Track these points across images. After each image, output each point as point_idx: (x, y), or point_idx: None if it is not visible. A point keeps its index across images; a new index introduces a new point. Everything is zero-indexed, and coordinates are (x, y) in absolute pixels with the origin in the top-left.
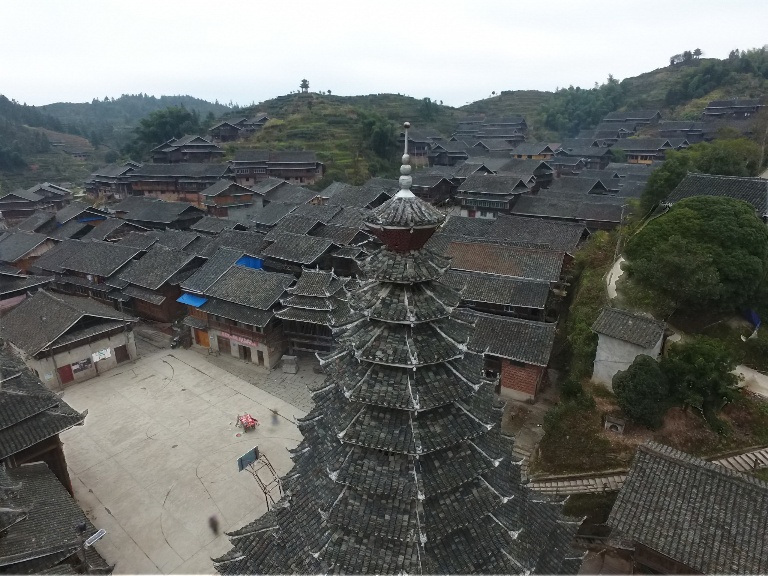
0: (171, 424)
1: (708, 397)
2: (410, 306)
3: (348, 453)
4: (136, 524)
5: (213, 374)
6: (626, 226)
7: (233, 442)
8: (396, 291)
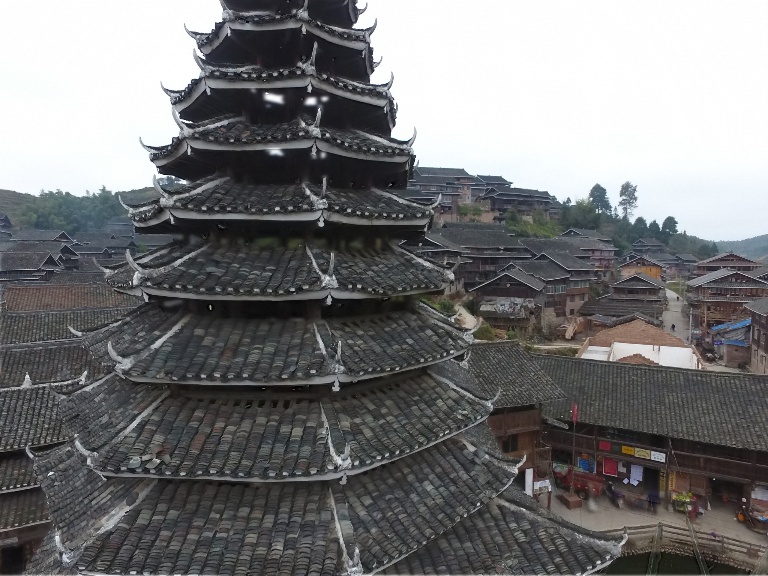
0: None
1: None
2: None
3: None
4: None
5: None
6: None
7: None
8: None
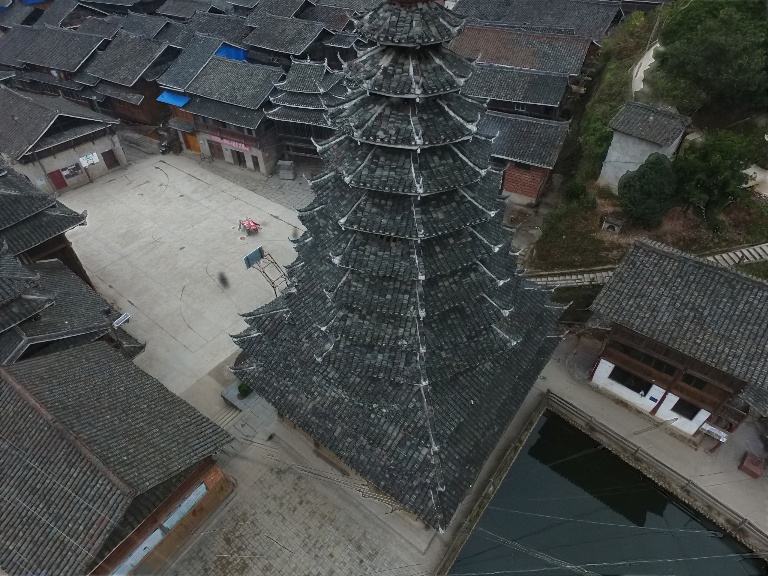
0: (175, 228)
1: (714, 196)
2: (416, 76)
3: (350, 240)
4: (159, 313)
5: (209, 180)
6: (670, 3)
7: (238, 244)
8: (400, 59)
